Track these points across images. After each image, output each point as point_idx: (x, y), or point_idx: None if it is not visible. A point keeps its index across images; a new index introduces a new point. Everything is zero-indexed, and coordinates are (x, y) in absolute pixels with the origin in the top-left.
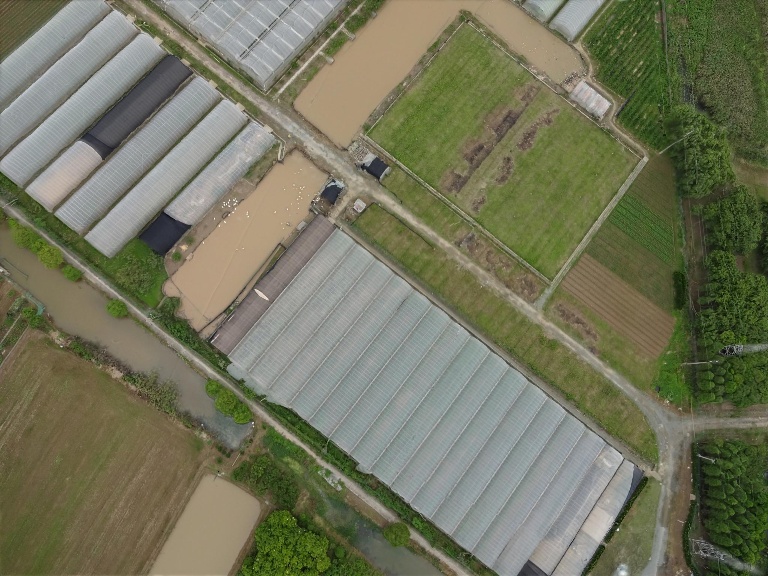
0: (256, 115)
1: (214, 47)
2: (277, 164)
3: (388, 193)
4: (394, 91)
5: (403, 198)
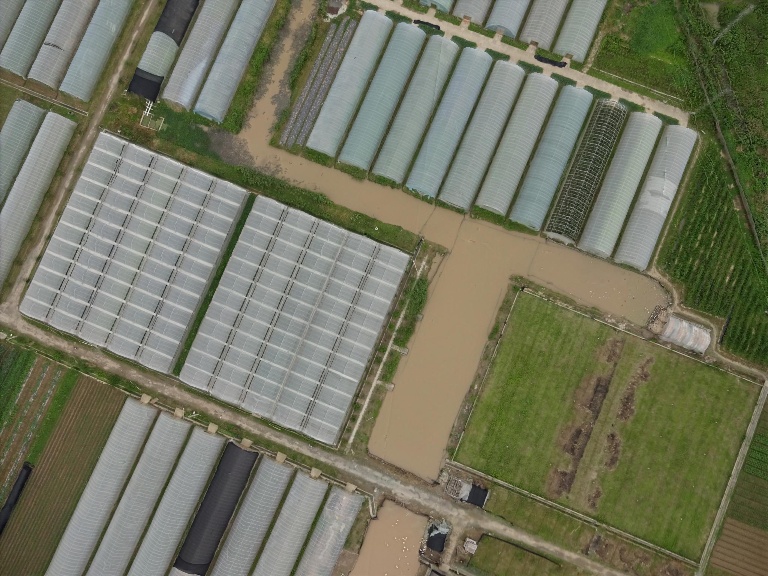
0: (335, 476)
1: (271, 421)
2: (372, 521)
3: (495, 518)
4: (467, 399)
5: (512, 519)
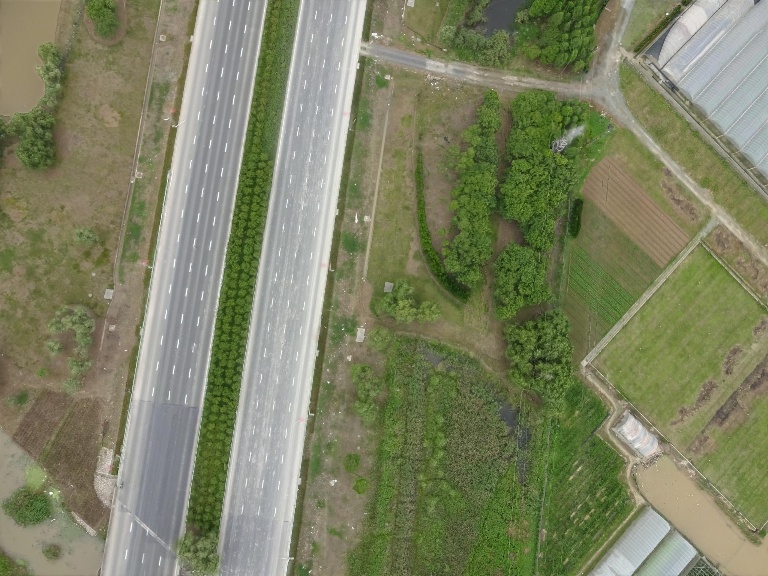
0: None
1: None
2: None
3: None
4: None
5: None
